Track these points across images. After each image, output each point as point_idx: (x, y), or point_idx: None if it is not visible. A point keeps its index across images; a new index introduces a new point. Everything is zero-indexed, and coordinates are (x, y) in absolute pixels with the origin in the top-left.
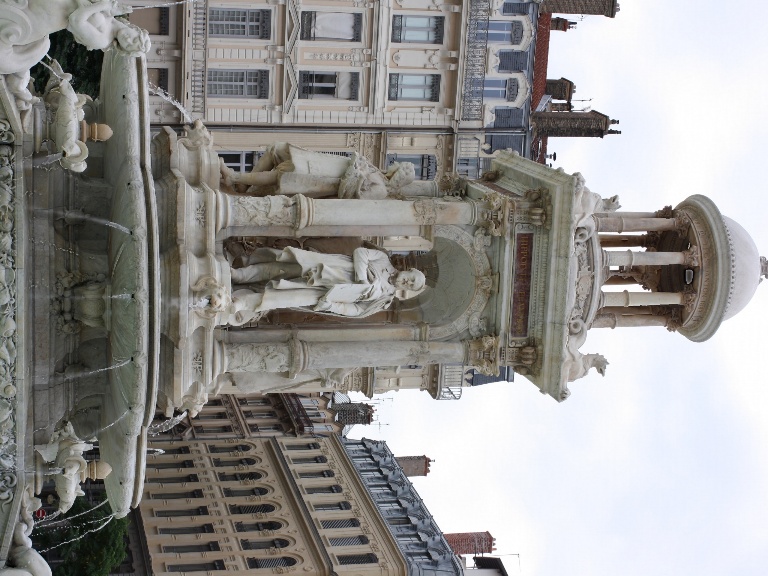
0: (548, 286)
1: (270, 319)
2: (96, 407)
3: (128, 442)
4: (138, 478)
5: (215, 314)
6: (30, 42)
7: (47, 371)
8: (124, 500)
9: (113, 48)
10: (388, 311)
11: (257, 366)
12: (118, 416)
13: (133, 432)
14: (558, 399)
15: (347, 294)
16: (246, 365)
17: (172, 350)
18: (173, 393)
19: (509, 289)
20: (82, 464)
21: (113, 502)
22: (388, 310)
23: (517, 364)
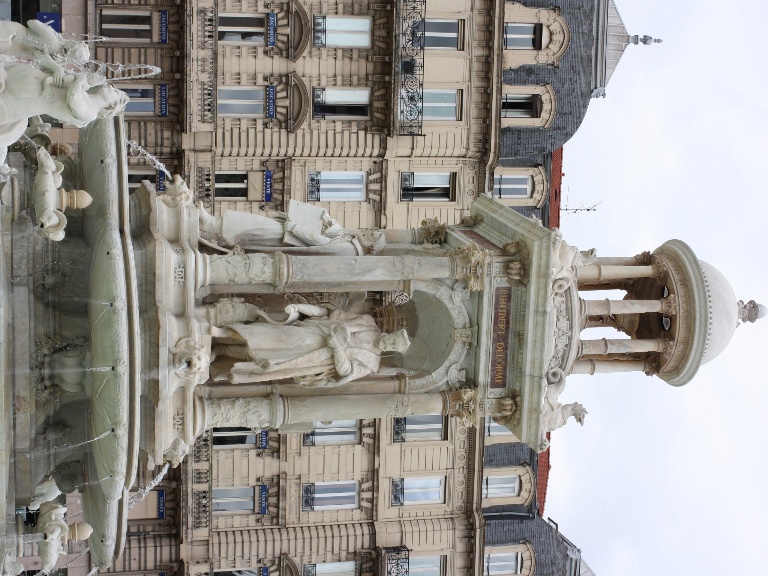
0: (499, 224)
1: (268, 382)
2: (83, 337)
3: (110, 225)
4: (128, 269)
5: (182, 199)
6: (1, 41)
7: (22, 178)
8: (115, 276)
9: (62, 56)
10: (392, 376)
11: (240, 259)
12: (94, 184)
13: (107, 152)
14: (550, 233)
15: (308, 218)
16: (228, 257)
17: (148, 232)
18: (154, 238)
19: (468, 240)
20: (59, 167)
21: (106, 315)
22: (391, 376)
23: (505, 257)
